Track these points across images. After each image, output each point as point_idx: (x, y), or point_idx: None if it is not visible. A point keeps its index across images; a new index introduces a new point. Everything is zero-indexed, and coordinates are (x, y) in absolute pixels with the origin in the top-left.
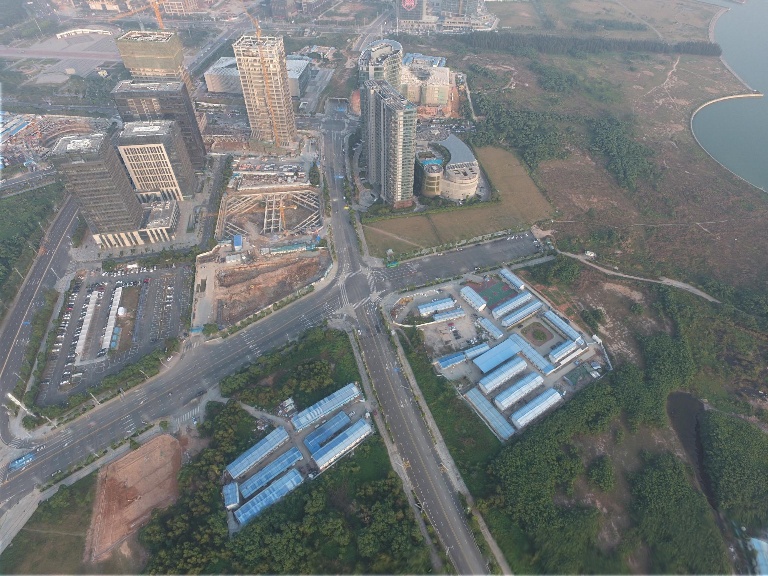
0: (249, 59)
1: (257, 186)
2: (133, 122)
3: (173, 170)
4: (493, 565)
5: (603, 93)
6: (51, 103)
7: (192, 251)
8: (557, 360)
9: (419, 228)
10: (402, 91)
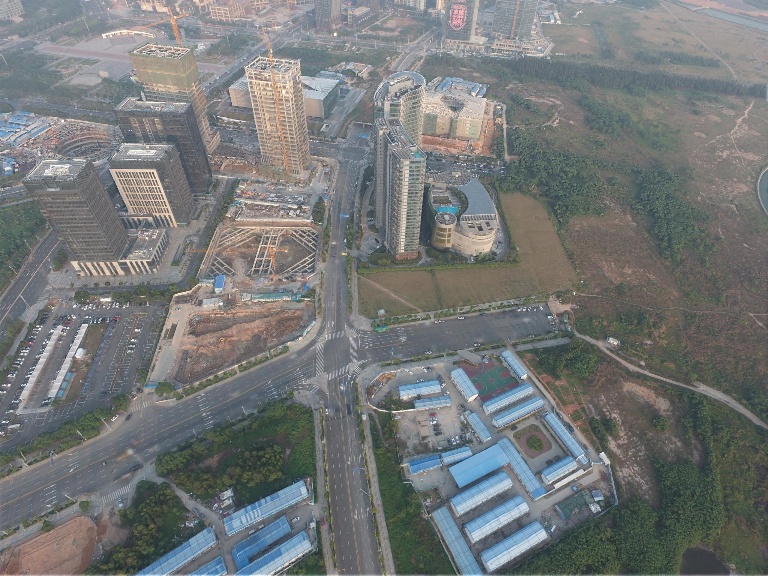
0: (261, 83)
1: (256, 218)
2: (130, 143)
3: (166, 196)
4: None
5: (658, 139)
6: (77, 107)
7: (169, 289)
8: (551, 481)
9: (420, 286)
10: (431, 121)
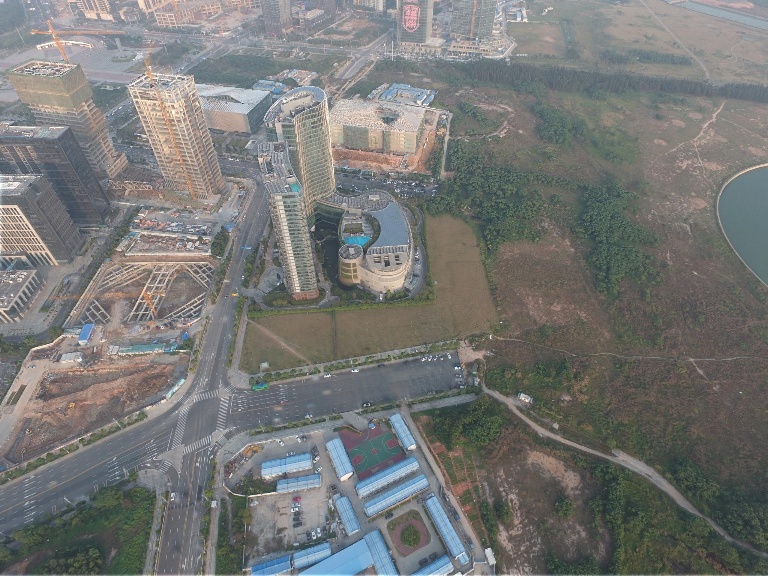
0: (148, 102)
1: (149, 252)
2: None
3: (38, 233)
4: None
5: (613, 148)
6: None
7: (25, 343)
8: None
9: (315, 331)
10: (362, 135)
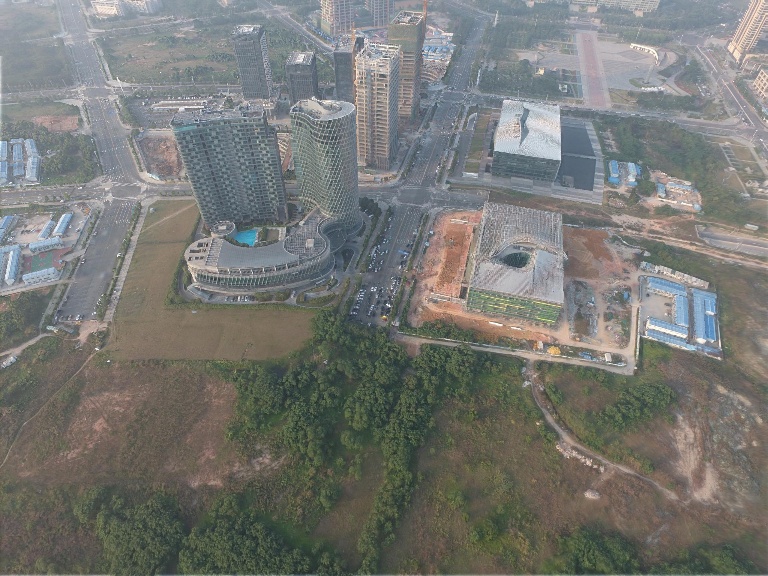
0: None
1: None
2: None
3: None
4: None
5: None
6: None
7: None
8: None
9: (171, 232)
10: None
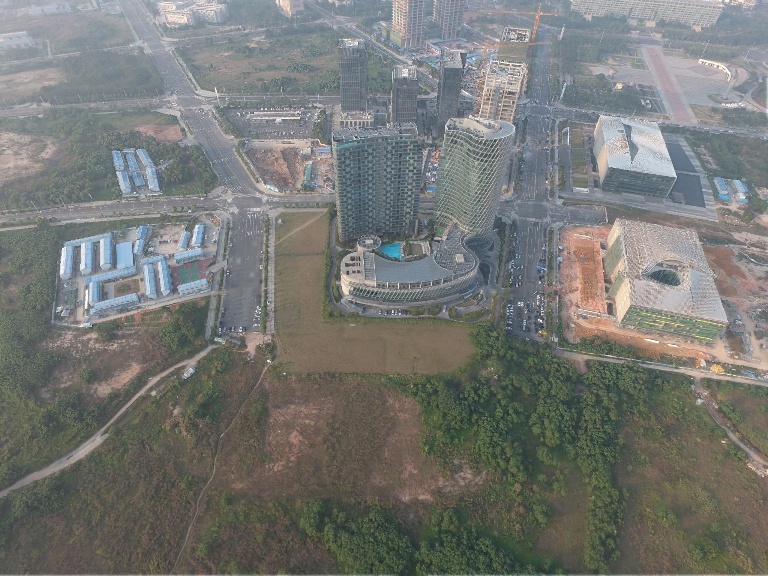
0: None
1: None
2: None
3: None
4: (11, 219)
5: None
6: None
7: None
8: None
9: (306, 244)
10: None
